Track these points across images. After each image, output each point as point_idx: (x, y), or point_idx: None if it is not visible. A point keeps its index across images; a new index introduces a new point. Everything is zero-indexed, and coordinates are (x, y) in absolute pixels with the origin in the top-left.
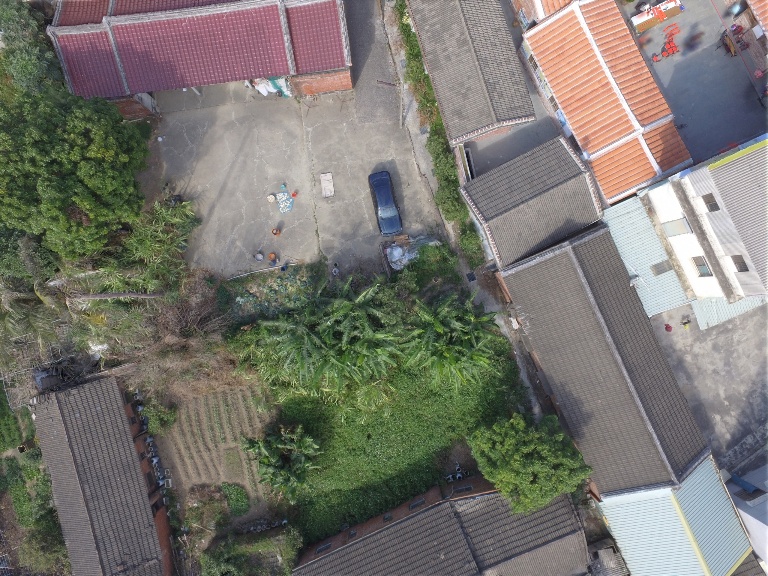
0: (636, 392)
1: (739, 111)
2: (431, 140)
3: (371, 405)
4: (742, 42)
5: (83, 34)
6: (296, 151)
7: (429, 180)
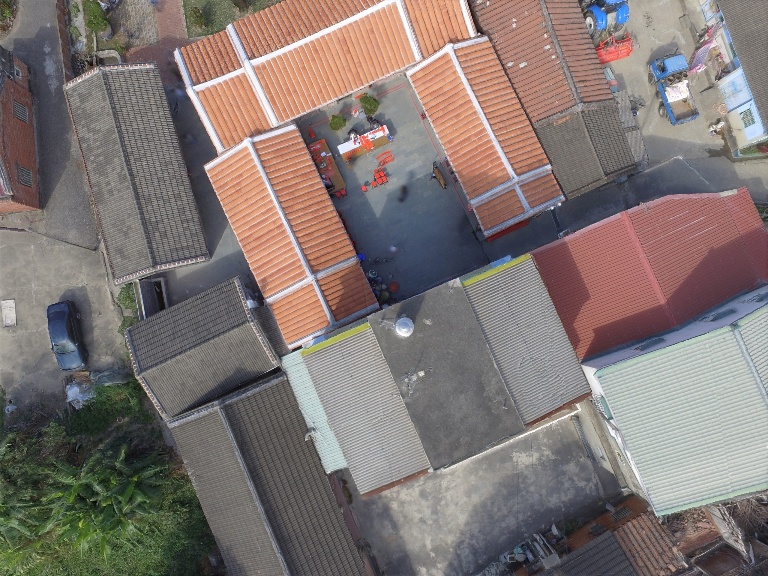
0: (286, 567)
1: (453, 244)
2: None
3: (14, 572)
4: None
5: None
6: None
7: (123, 309)
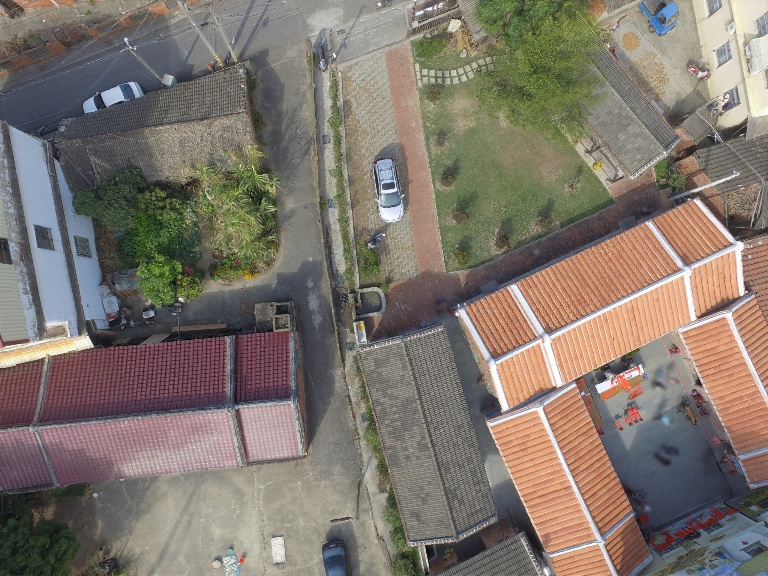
0: None
1: (698, 475)
2: (390, 511)
3: None
4: (702, 407)
5: (7, 432)
6: (246, 509)
7: (387, 543)
